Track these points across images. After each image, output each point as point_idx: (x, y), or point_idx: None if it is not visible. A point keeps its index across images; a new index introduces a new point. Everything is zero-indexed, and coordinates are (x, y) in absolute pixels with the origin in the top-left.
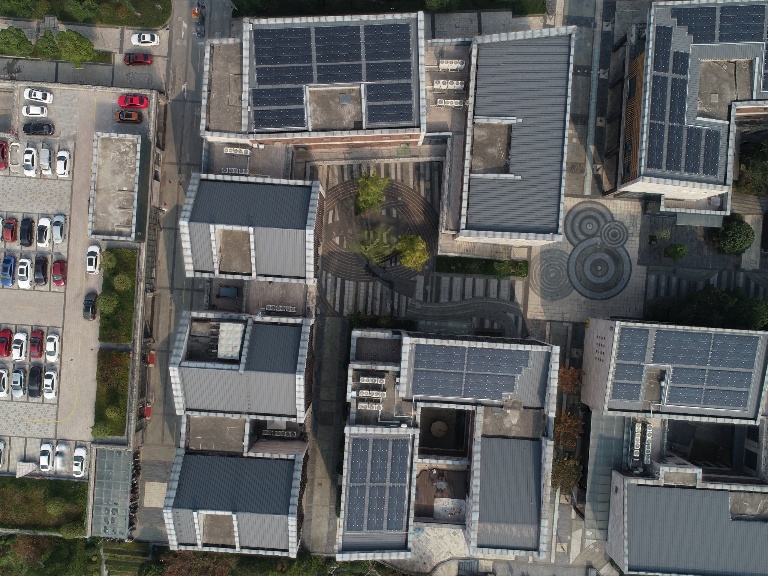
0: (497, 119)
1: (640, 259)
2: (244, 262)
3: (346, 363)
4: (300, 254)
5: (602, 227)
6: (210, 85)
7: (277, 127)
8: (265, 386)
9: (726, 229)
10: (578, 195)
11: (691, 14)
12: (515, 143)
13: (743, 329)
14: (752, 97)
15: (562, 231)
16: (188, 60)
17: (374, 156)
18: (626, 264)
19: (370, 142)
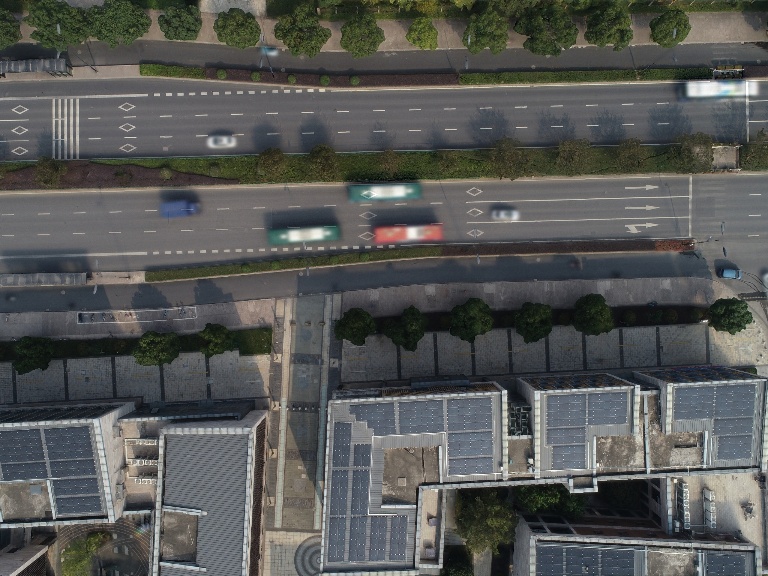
0: (183, 511)
1: None
2: None
3: None
4: None
5: None
6: None
7: None
8: None
9: (446, 573)
10: (308, 530)
11: (369, 410)
12: (200, 535)
13: None
14: (439, 481)
15: (293, 566)
16: None
17: None
18: None
19: None
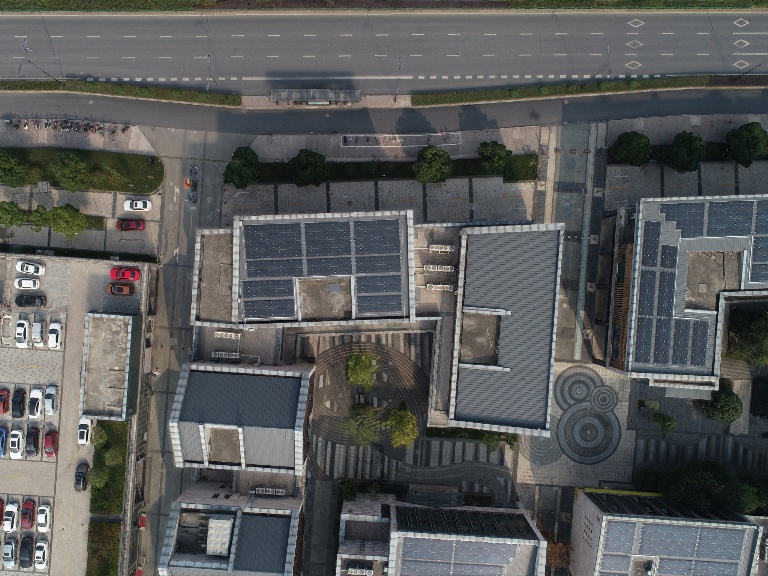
0: (486, 311)
1: (629, 424)
2: (234, 452)
3: (336, 529)
4: (289, 448)
5: (592, 392)
6: (201, 274)
7: (267, 317)
8: None
9: (715, 400)
10: (568, 360)
11: (679, 209)
12: (504, 335)
13: (730, 512)
14: (740, 287)
15: (552, 396)
16: (180, 225)
17: (364, 328)
18: (615, 429)
19: None
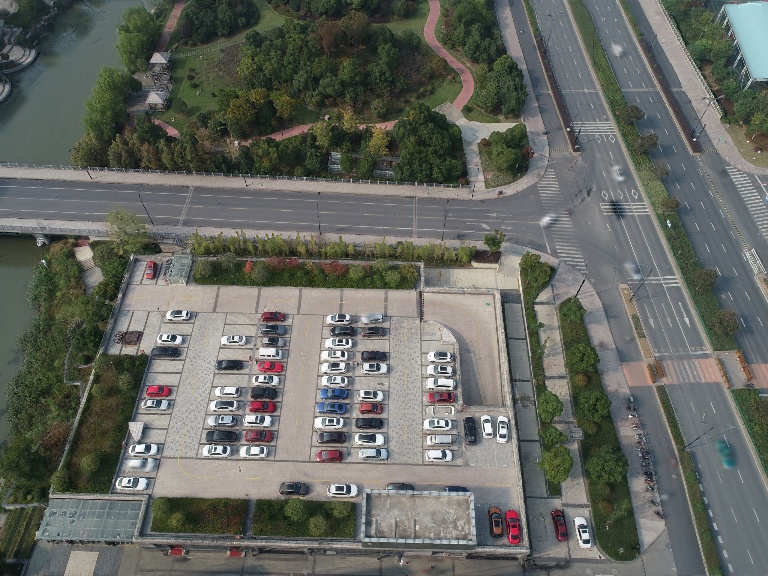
0: None
1: None
2: None
3: None
4: None
5: None
6: None
7: None
8: None
9: None
10: None
11: None
12: None
13: None
14: None
15: None
16: None
17: None
18: None
19: None
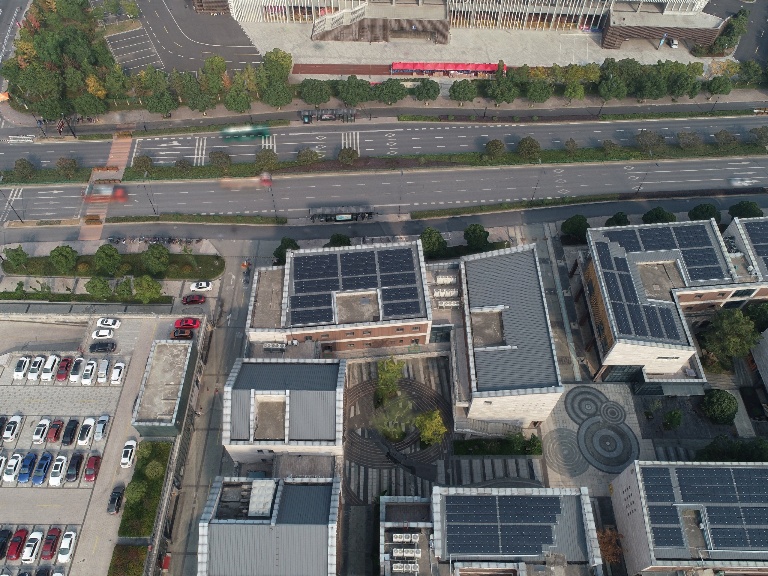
0: (489, 308)
1: (643, 433)
2: (277, 429)
3: (374, 552)
4: (330, 416)
5: (600, 407)
6: (256, 298)
7: (310, 323)
8: (296, 543)
9: (710, 397)
10: (571, 382)
11: (618, 235)
12: (507, 323)
13: None
14: (685, 285)
15: (565, 412)
16: (234, 299)
17: (389, 354)
18: (632, 438)
19: (386, 338)
